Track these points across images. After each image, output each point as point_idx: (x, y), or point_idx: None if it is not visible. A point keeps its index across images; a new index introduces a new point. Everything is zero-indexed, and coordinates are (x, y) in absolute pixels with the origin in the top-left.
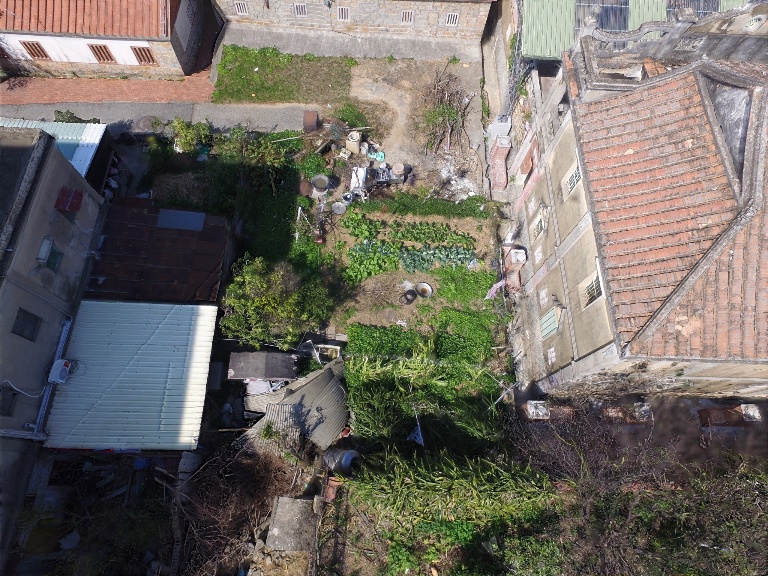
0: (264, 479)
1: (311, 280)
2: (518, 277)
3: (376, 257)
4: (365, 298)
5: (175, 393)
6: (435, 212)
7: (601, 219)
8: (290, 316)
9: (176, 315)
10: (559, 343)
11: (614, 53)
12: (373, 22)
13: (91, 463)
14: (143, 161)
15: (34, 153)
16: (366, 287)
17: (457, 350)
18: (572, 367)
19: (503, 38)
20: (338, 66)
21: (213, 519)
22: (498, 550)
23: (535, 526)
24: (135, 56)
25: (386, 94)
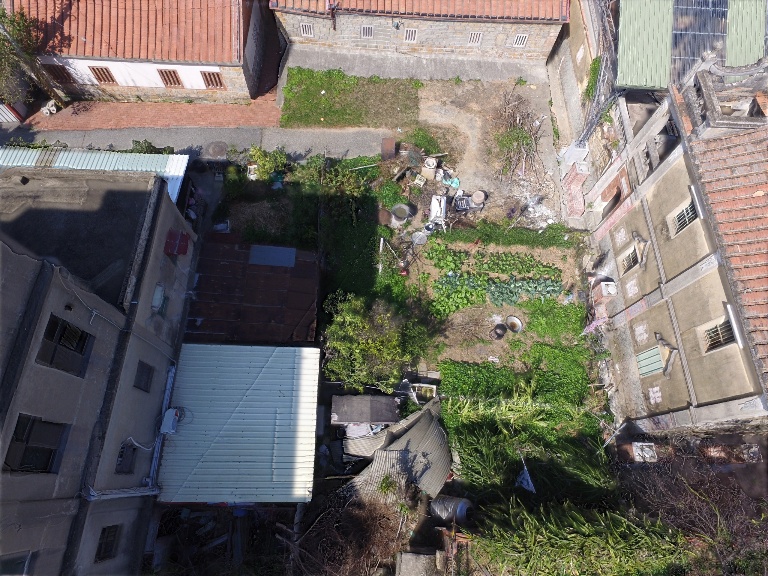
0: (370, 527)
1: (399, 315)
2: (605, 309)
3: (464, 290)
4: (454, 333)
5: (284, 441)
6: (518, 242)
7: (734, 265)
8: (395, 358)
9: (279, 358)
10: (667, 384)
11: (726, 87)
12: (439, 43)
13: (189, 509)
14: (216, 189)
15: (151, 199)
16: (454, 321)
17: (553, 388)
18: (691, 413)
19: (572, 59)
20: (405, 88)
21: (335, 575)
22: None
23: None
24: (203, 80)
25: (455, 117)
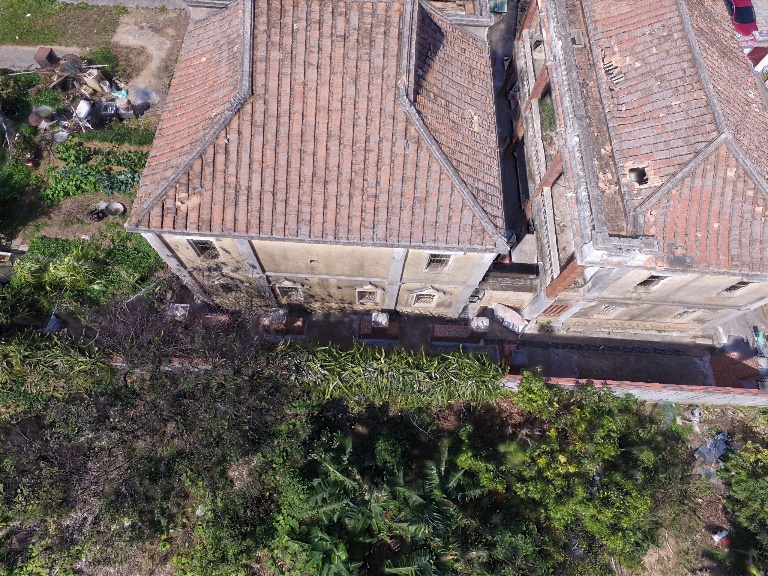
0: None
1: (7, 196)
2: None
3: (75, 178)
4: (58, 215)
5: None
6: (149, 142)
7: (163, 117)
8: None
9: None
10: None
11: None
12: None
13: None
14: None
15: None
16: (63, 205)
17: (127, 261)
18: None
19: None
20: (109, 14)
21: None
22: (41, 410)
23: (110, 400)
24: None
25: (147, 40)
